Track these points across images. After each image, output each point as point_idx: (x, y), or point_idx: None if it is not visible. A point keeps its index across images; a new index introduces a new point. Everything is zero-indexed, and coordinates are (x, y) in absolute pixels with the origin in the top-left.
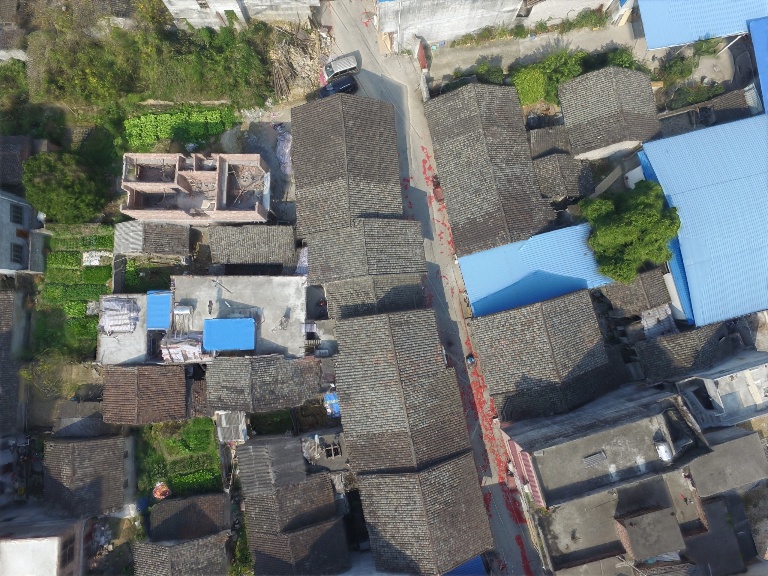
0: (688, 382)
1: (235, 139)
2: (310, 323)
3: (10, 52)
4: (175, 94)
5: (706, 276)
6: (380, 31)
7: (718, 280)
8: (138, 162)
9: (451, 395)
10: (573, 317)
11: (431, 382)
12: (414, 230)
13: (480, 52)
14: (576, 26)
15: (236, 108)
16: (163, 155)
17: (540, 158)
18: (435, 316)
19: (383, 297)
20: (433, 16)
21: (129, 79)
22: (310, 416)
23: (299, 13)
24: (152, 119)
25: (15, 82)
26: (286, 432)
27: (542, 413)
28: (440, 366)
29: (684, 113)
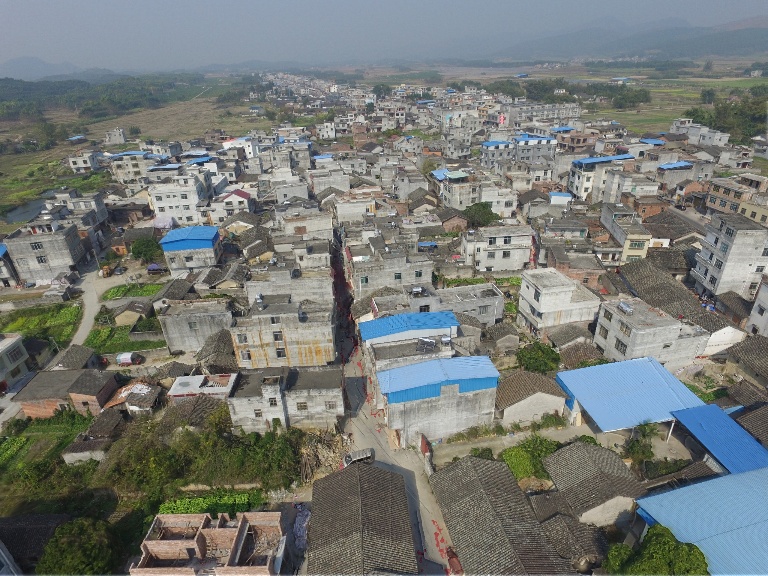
0: None
1: None
2: None
3: (93, 453)
4: (215, 478)
5: None
6: (390, 428)
7: None
8: (165, 525)
9: None
10: None
11: None
12: None
13: (472, 446)
14: (543, 426)
15: (264, 491)
16: (192, 515)
17: (546, 520)
18: None
19: None
20: (429, 416)
21: (180, 469)
22: None
23: (328, 422)
24: (186, 502)
25: (81, 478)
26: None
27: None
28: None
29: (665, 484)
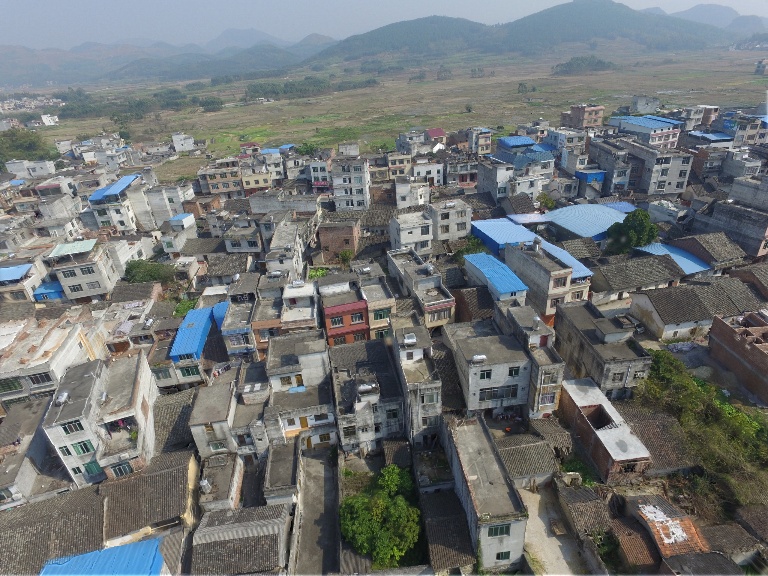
0: None
1: None
2: None
3: None
4: None
5: None
6: None
7: None
8: None
9: None
10: None
11: None
12: None
13: None
14: None
15: None
16: None
17: None
18: None
19: None
20: None
21: None
22: None
23: None
24: None
25: None
26: None
27: None
28: None
29: None
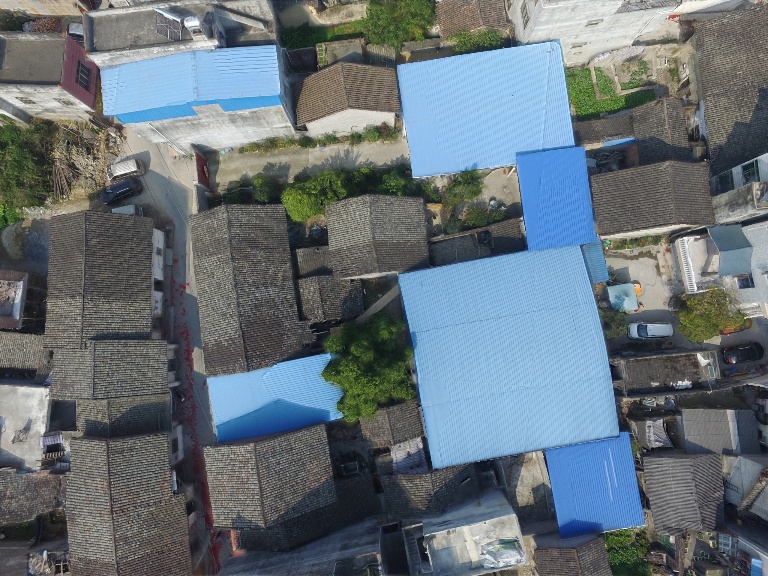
0: (416, 528)
1: (13, 236)
2: (53, 435)
3: None
4: None
5: (445, 419)
6: (149, 141)
7: (457, 423)
8: None
9: (176, 523)
10: (298, 455)
11: (152, 511)
12: (158, 350)
13: (268, 159)
14: (365, 139)
15: None
16: None
17: (304, 278)
18: (168, 440)
19: (119, 417)
20: (198, 131)
21: None
22: (59, 523)
23: (79, 115)
24: None
25: None
26: (32, 539)
27: (269, 547)
28: (166, 493)
29: (467, 235)
